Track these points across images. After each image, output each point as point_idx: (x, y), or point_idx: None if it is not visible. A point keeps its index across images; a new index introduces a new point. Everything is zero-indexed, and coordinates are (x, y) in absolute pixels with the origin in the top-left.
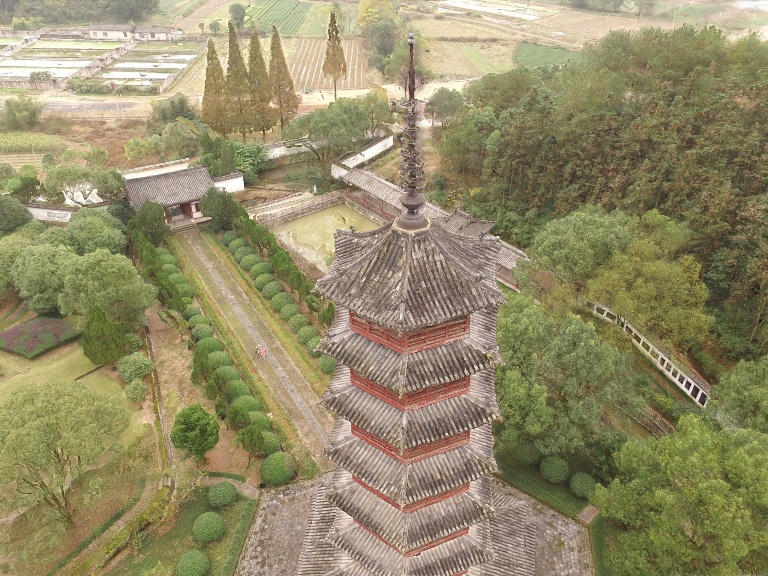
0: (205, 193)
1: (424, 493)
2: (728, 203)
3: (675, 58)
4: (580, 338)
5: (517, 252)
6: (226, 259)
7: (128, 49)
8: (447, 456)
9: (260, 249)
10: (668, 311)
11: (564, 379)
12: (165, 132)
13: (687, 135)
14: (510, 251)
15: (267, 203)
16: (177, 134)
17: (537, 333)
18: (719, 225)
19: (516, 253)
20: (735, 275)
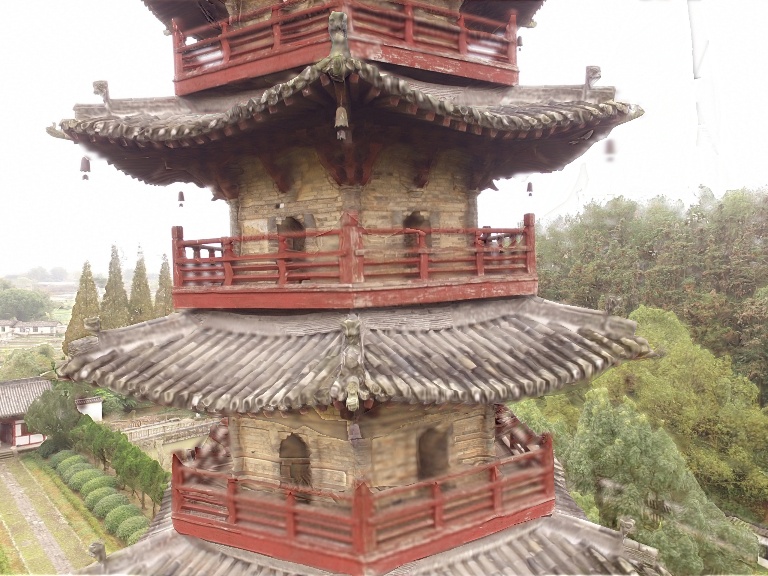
0: (37, 397)
1: (431, 382)
2: (721, 306)
3: (595, 220)
4: (619, 419)
5: None
6: (48, 482)
7: (2, 340)
8: (480, 332)
9: (104, 464)
10: (717, 411)
11: (614, 494)
12: (8, 363)
13: (637, 270)
14: None
15: (129, 428)
16: (24, 365)
17: (546, 427)
18: (722, 331)
19: None
20: (763, 402)
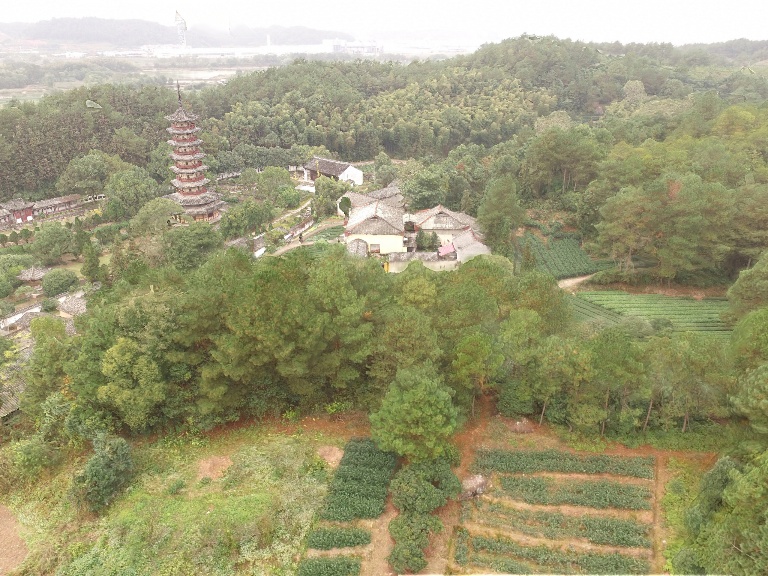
0: None
1: None
2: None
3: (4, 120)
4: None
5: (49, 199)
6: None
7: None
8: None
9: None
10: None
11: None
12: None
13: None
14: (47, 201)
15: None
16: None
17: None
18: None
19: (49, 200)
20: None
